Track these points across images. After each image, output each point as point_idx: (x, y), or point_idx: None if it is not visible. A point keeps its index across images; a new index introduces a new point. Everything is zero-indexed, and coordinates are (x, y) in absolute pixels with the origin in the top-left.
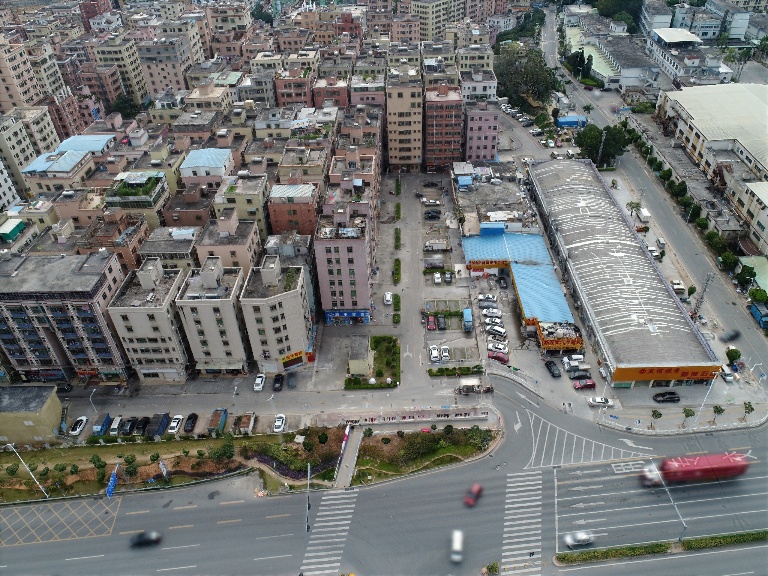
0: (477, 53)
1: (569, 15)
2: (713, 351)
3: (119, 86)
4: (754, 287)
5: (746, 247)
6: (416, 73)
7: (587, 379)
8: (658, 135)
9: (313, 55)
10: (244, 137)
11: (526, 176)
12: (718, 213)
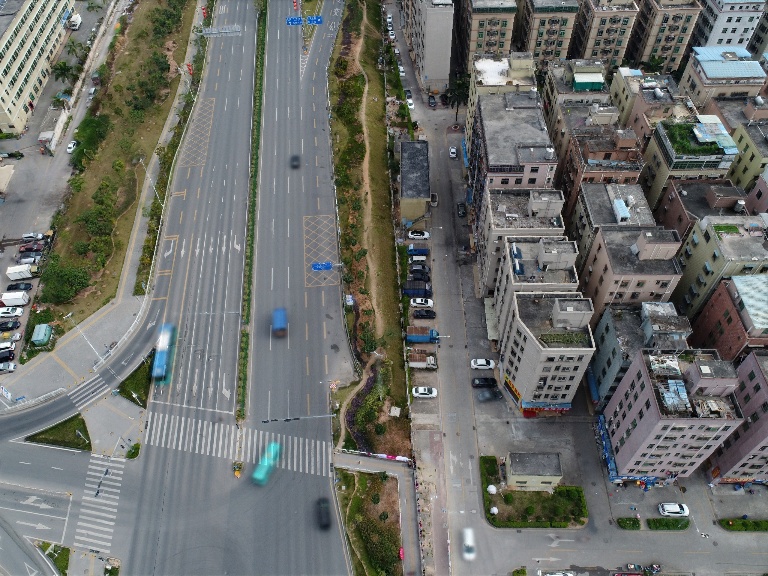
0: None
1: None
2: None
3: None
4: None
5: None
6: None
7: None
8: None
9: None
10: None
11: None
12: None
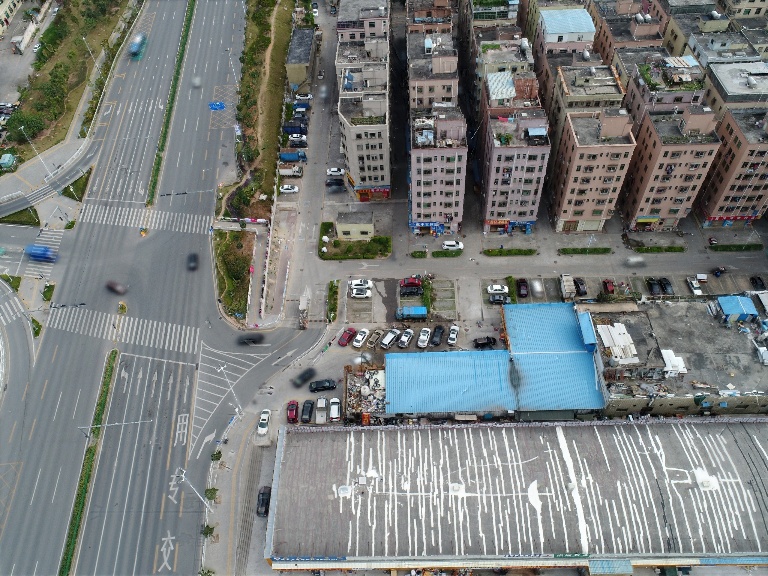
0: None
1: None
2: None
3: None
4: None
5: None
6: None
7: None
8: None
9: None
10: None
11: None
12: None
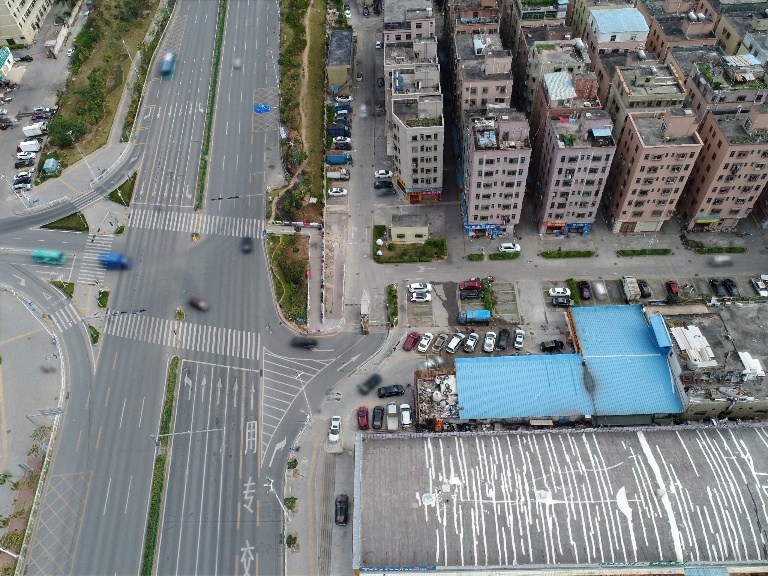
0: None
1: None
2: None
3: None
4: None
5: None
6: None
7: None
8: None
9: None
10: None
11: None
12: None
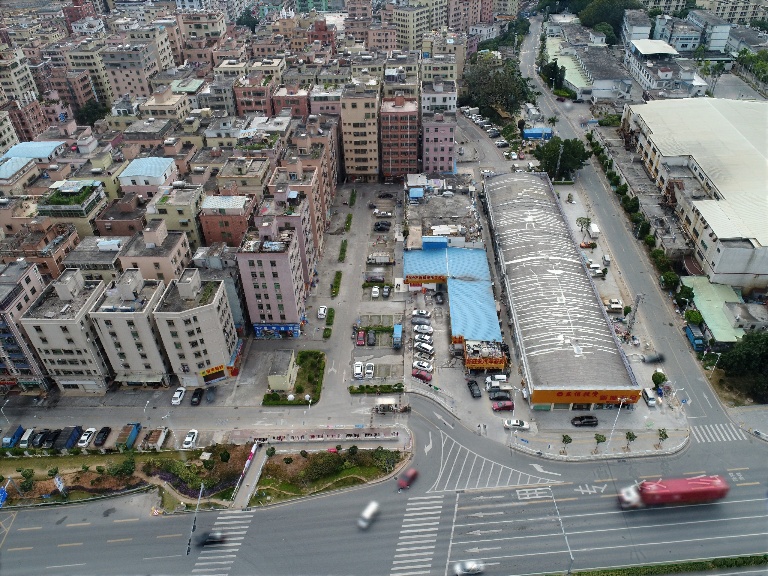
0: (440, 63)
1: (551, 25)
2: (641, 374)
3: (90, 91)
4: (692, 308)
5: (690, 266)
6: (376, 83)
7: (506, 400)
8: (620, 149)
9: (277, 63)
10: (193, 146)
11: (482, 189)
12: (666, 231)
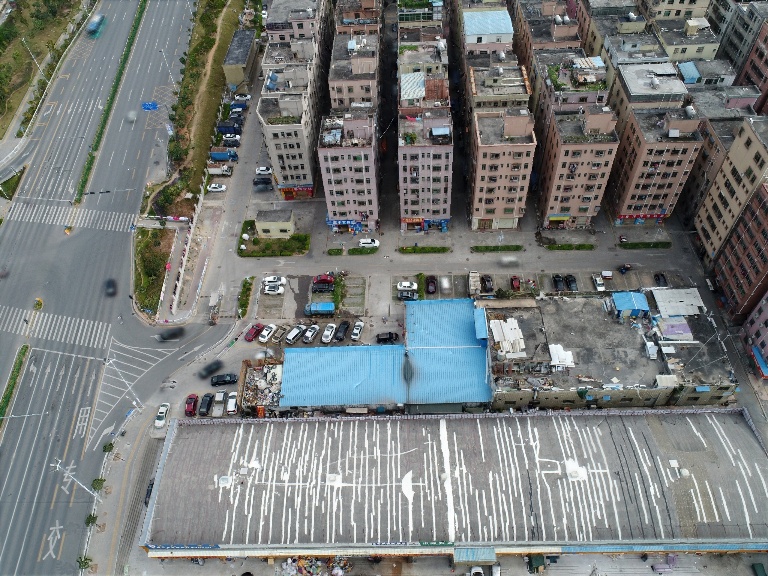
0: None
1: None
2: None
3: None
4: None
5: None
6: None
7: None
8: None
9: None
10: None
11: None
12: None
